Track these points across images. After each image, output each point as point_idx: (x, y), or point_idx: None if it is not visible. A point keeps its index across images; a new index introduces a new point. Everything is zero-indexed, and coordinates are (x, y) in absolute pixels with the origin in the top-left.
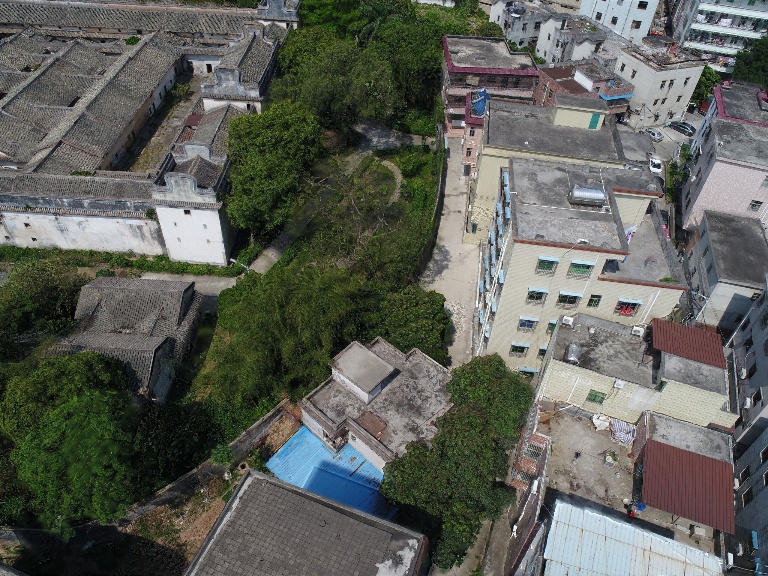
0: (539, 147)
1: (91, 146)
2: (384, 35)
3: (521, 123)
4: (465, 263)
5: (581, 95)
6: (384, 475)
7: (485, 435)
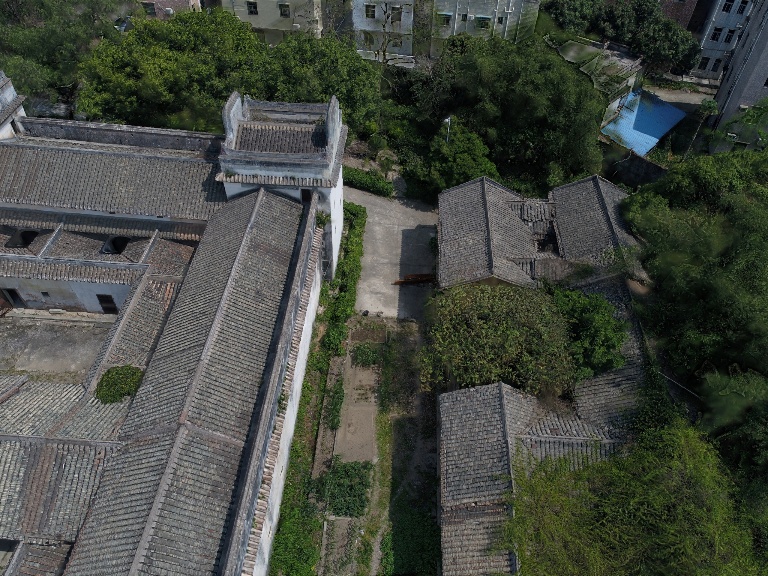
0: None
1: None
2: None
3: None
4: None
5: None
6: (668, 53)
7: (631, 1)
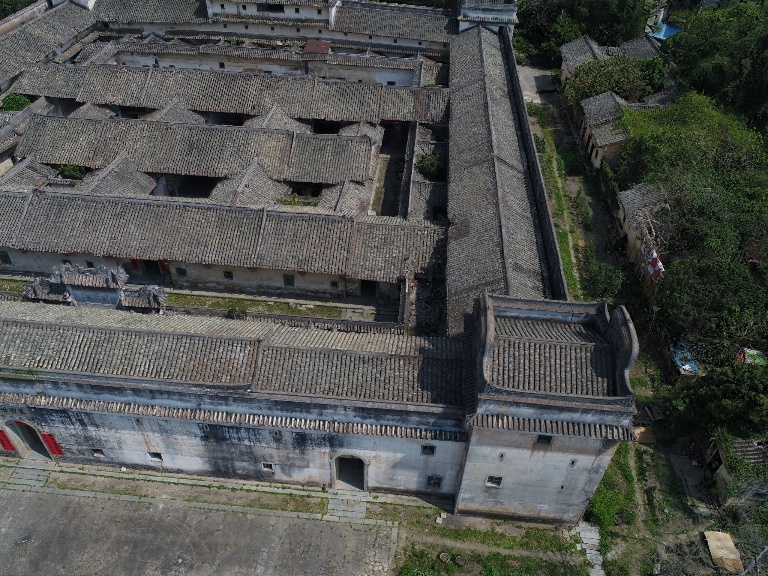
0: None
1: None
2: None
3: None
4: None
5: None
6: None
7: None
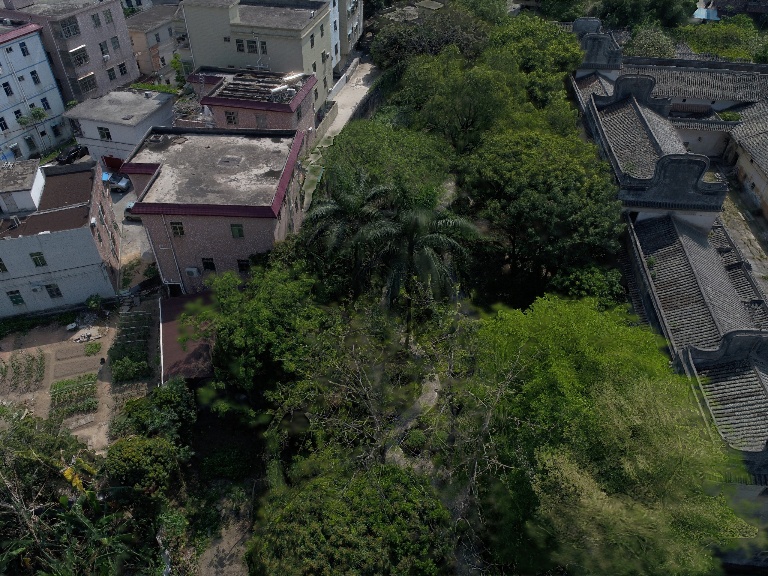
0: (274, 11)
1: (762, 138)
2: None
3: (274, 25)
4: (341, 104)
5: (78, 167)
6: None
7: None
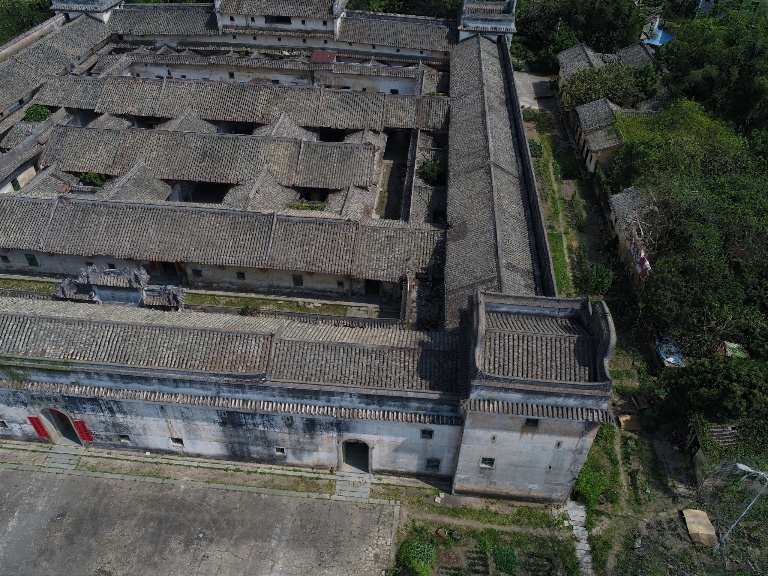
0: None
1: None
2: None
3: None
4: None
5: None
6: (679, 1)
7: None
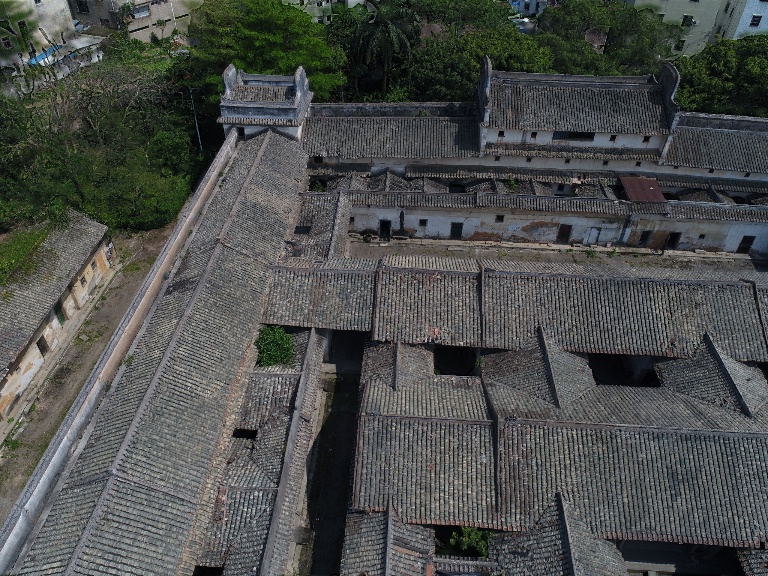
0: None
1: None
2: (481, 4)
3: None
4: None
5: None
6: None
7: None
